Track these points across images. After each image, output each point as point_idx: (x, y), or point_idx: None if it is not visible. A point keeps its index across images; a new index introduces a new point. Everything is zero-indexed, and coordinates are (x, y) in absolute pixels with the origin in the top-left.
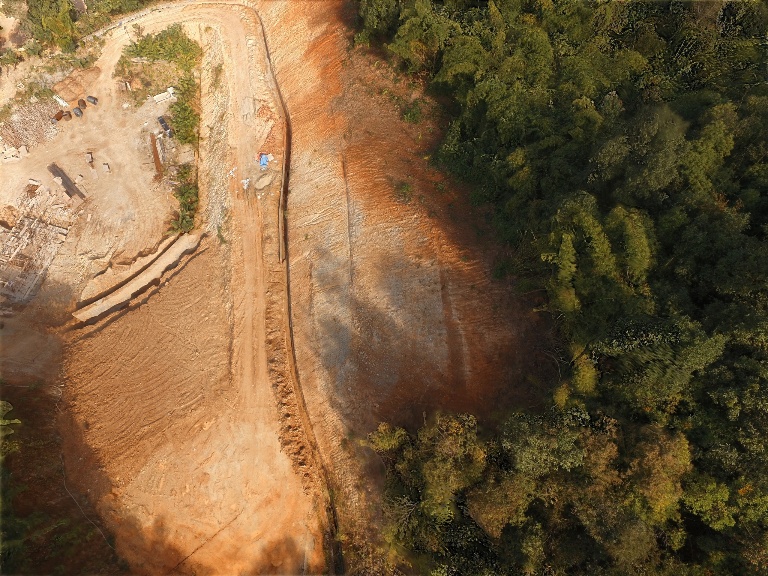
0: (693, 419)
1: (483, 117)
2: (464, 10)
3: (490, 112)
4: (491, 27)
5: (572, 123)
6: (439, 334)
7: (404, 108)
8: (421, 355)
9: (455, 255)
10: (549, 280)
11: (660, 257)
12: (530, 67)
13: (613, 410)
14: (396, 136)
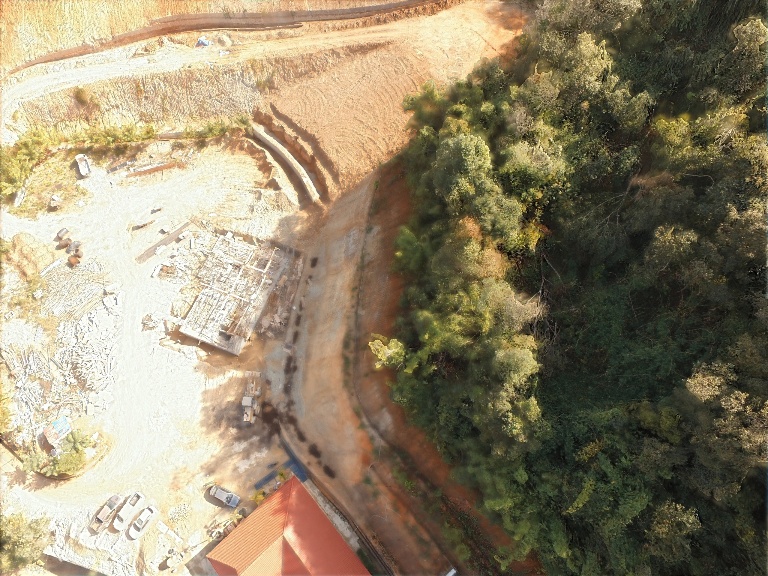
0: None
1: None
2: None
3: None
4: None
5: None
6: None
7: None
8: None
9: None
10: None
11: None
12: None
13: None
14: None
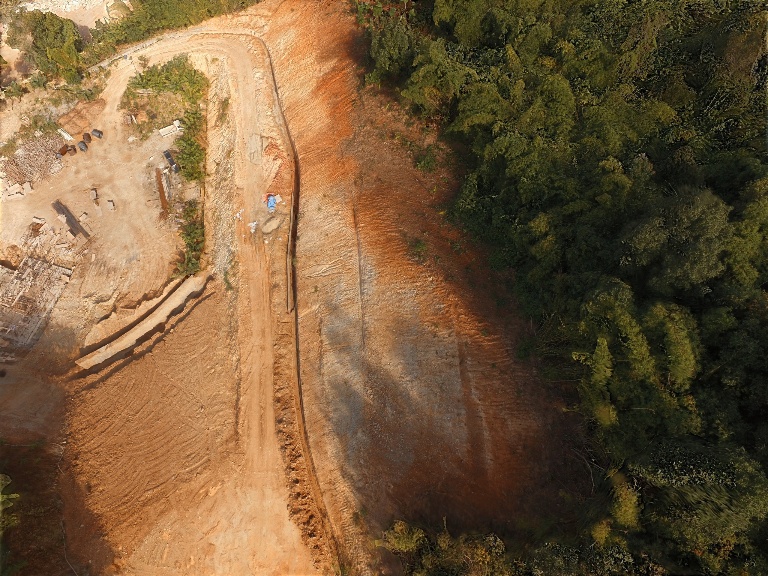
0: (750, 567)
1: (502, 172)
2: (479, 48)
3: (510, 169)
4: (509, 73)
5: (598, 186)
6: (458, 414)
7: (417, 154)
8: (438, 435)
9: (474, 327)
10: (581, 380)
11: (705, 363)
12: (551, 117)
13: (659, 553)
14: (409, 185)
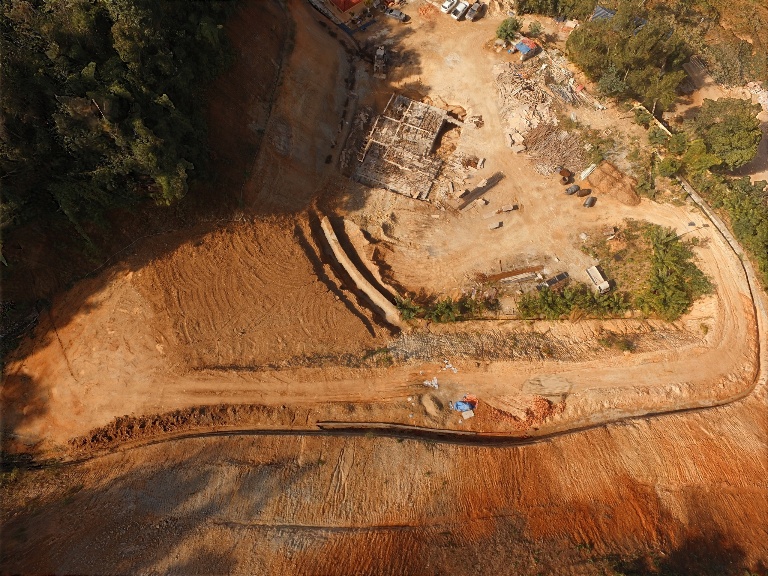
0: None
1: None
2: None
3: None
4: None
5: None
6: None
7: None
8: None
9: None
10: None
11: None
12: None
13: None
14: None
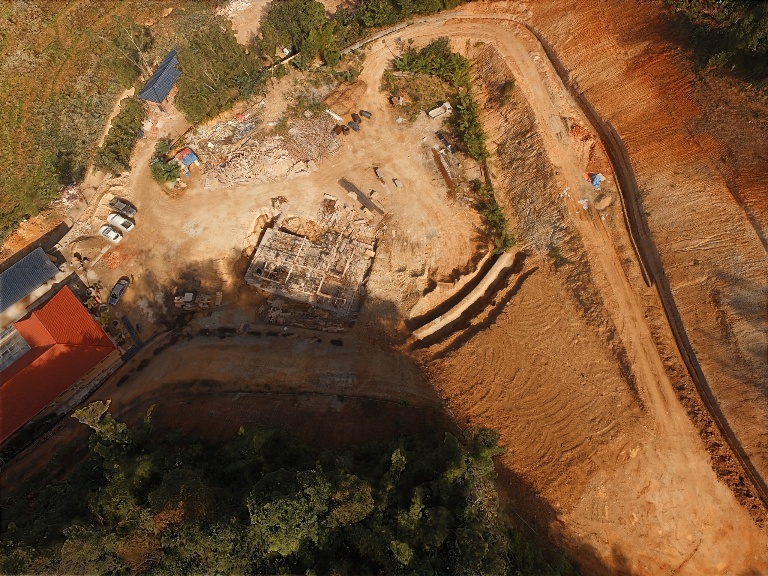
0: None
1: None
2: None
3: None
4: None
5: None
6: None
7: None
8: None
9: None
10: None
11: None
12: None
13: None
14: None
